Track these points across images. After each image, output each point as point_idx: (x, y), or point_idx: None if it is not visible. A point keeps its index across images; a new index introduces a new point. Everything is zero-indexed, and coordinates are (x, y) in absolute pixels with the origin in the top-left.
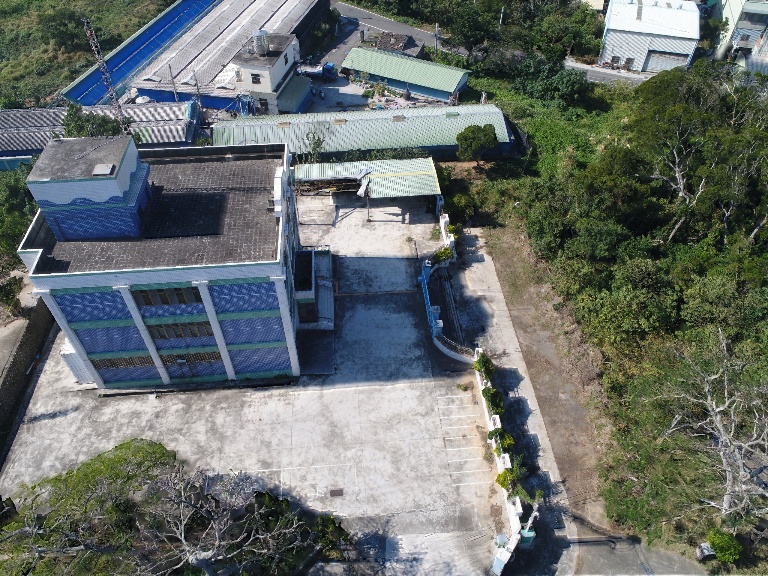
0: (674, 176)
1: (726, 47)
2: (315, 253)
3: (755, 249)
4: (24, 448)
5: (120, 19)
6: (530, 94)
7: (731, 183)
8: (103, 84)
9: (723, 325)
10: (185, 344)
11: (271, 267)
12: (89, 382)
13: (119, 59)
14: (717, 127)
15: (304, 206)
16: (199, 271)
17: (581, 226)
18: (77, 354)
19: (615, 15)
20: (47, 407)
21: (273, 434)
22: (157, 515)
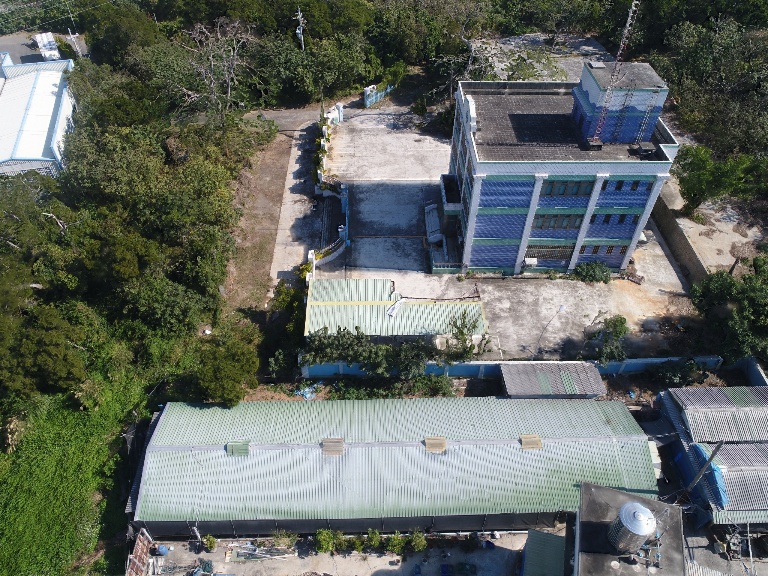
0: None
1: None
2: None
3: None
4: None
5: None
6: None
7: None
8: None
9: None
10: None
11: None
12: None
13: None
14: None
15: None
16: None
17: None
18: None
19: None
20: None
21: None
22: None
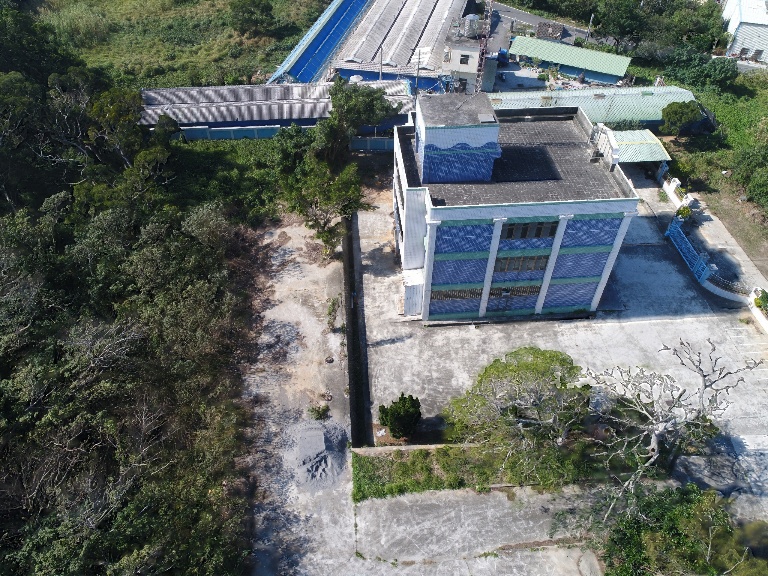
0: None
1: None
2: None
3: None
4: (380, 366)
5: (288, 8)
6: (680, 81)
7: None
8: (311, 64)
9: None
10: (516, 277)
11: (630, 203)
12: (412, 314)
13: (317, 42)
14: None
15: None
16: (570, 206)
17: None
18: (425, 285)
19: (747, 9)
20: (383, 334)
21: (594, 357)
22: (614, 394)
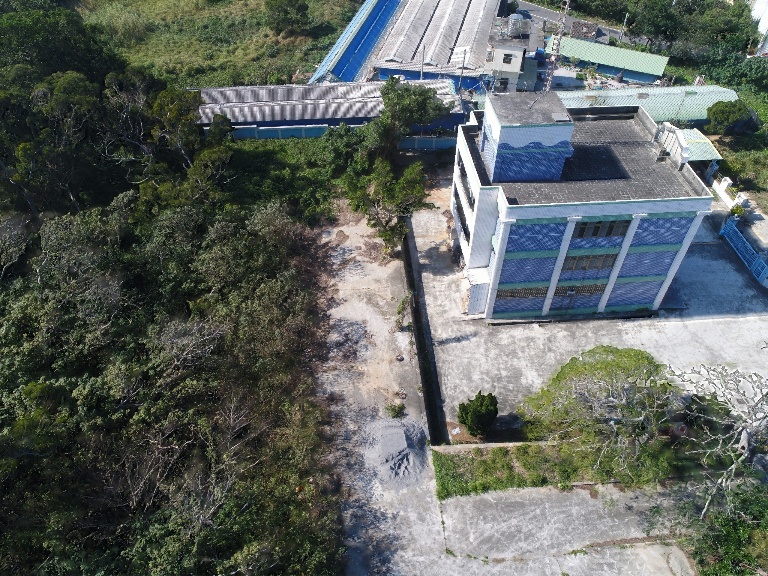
0: None
1: None
2: None
3: None
4: (448, 365)
5: (322, 8)
6: (715, 80)
7: None
8: (352, 64)
9: None
10: (582, 276)
11: (704, 202)
12: (475, 313)
13: (357, 42)
14: None
15: None
16: (645, 204)
17: None
18: (492, 283)
19: None
20: (448, 333)
21: (661, 355)
22: (704, 392)
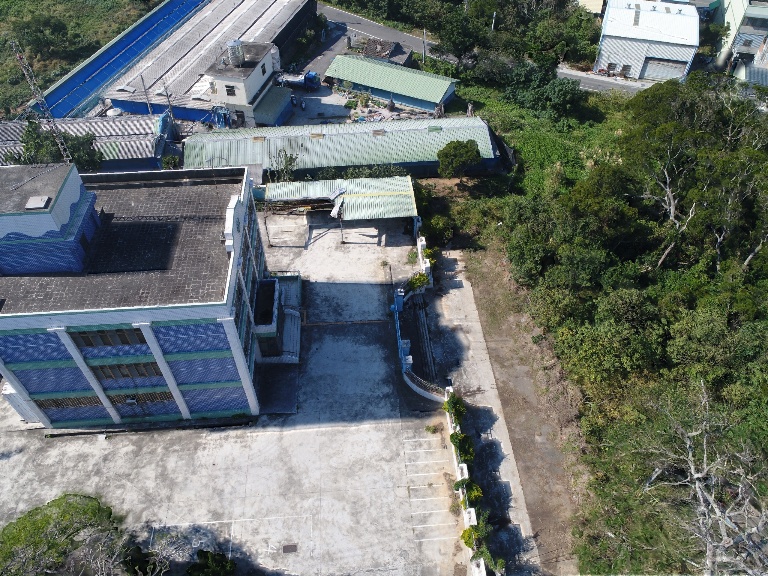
0: (665, 196)
1: (726, 55)
2: (284, 278)
3: (750, 276)
4: None
5: (99, 25)
6: (521, 104)
7: (724, 206)
8: (75, 95)
9: (711, 364)
10: (133, 384)
11: (217, 308)
12: (36, 421)
13: (93, 68)
14: (710, 146)
15: (276, 226)
16: (140, 313)
17: (562, 254)
18: (18, 395)
19: None
20: None
21: (226, 481)
22: None
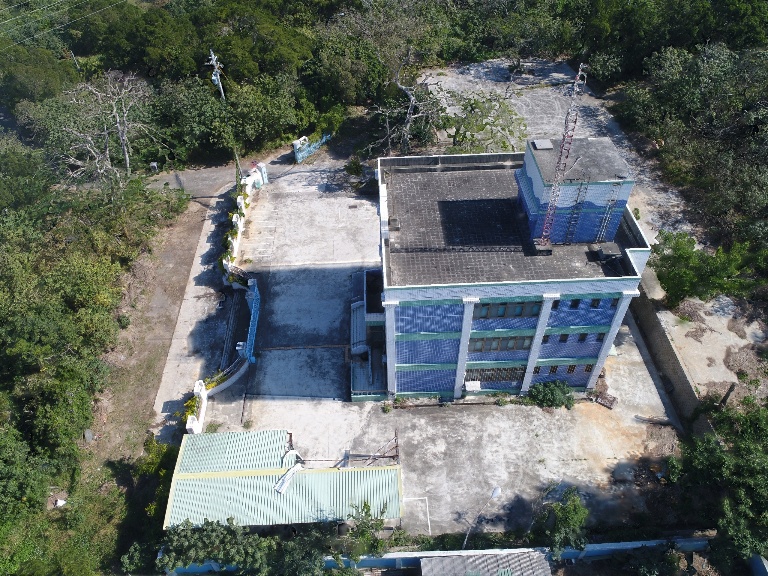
0: None
1: None
2: None
3: None
4: None
5: None
6: None
7: None
8: None
9: None
10: None
11: None
12: None
13: None
14: None
15: None
16: (444, 160)
17: None
18: None
19: None
20: None
21: None
22: None
